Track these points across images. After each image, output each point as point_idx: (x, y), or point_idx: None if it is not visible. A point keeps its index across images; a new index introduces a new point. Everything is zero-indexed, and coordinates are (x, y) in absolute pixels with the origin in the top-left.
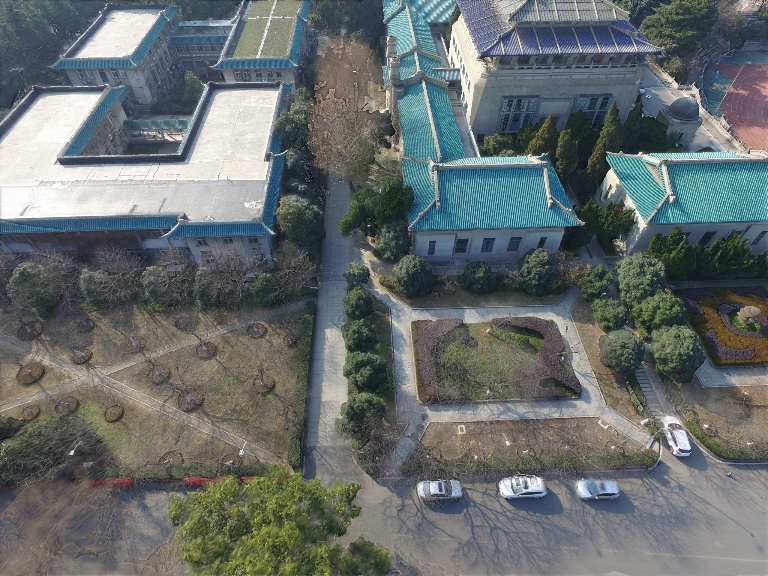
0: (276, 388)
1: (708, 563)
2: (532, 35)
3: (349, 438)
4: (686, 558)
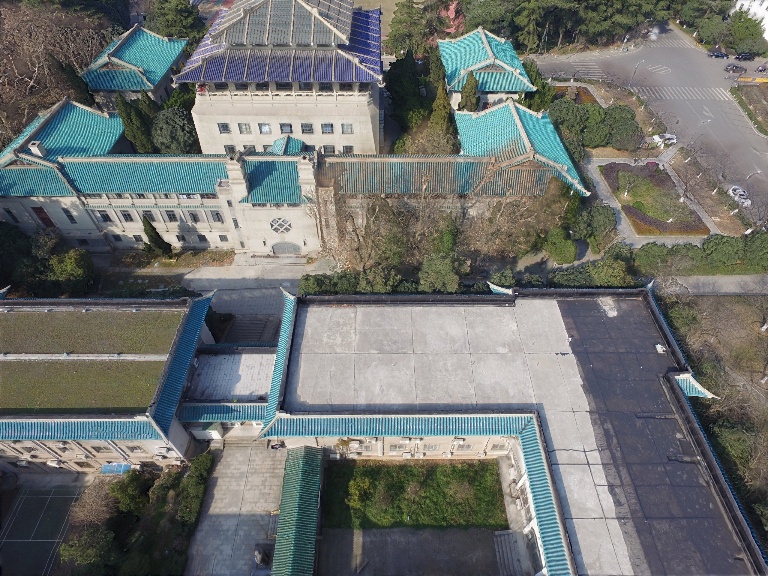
0: (759, 321)
1: (728, 149)
2: (351, 46)
3: (764, 275)
4: (731, 155)
